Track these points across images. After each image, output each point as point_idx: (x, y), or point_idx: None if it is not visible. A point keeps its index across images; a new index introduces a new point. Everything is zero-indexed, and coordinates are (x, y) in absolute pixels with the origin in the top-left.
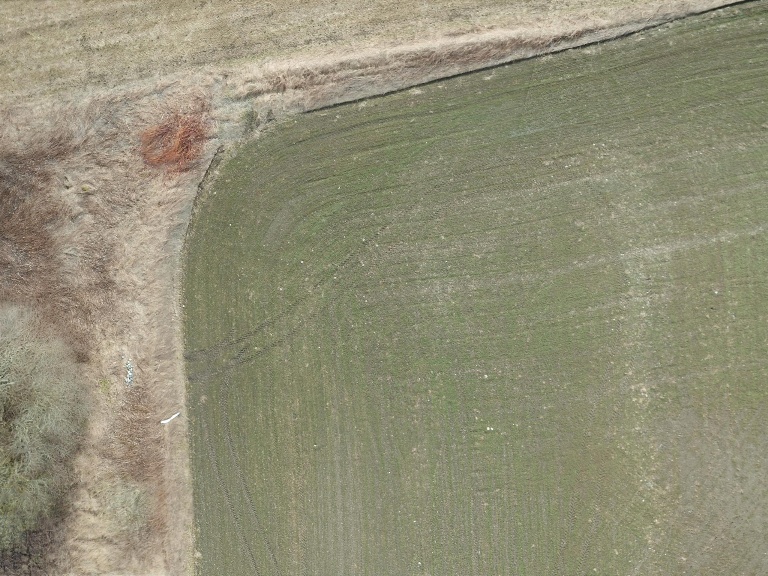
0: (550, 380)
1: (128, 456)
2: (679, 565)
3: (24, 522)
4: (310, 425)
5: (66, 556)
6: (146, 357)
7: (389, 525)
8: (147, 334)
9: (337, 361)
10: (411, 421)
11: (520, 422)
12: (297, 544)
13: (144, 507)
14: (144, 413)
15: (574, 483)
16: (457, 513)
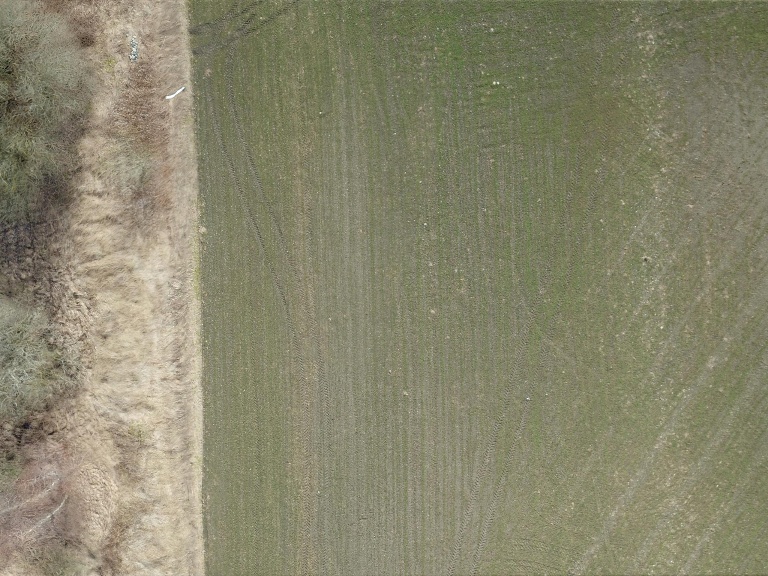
0: (556, 30)
1: (133, 133)
2: (686, 213)
3: (28, 215)
4: (315, 93)
5: (70, 244)
6: (151, 33)
7: (395, 187)
8: (152, 10)
9: (342, 26)
10: (417, 80)
11: (526, 75)
12: (302, 214)
13: (149, 184)
14: (149, 89)
15: (580, 134)
16: (463, 171)
